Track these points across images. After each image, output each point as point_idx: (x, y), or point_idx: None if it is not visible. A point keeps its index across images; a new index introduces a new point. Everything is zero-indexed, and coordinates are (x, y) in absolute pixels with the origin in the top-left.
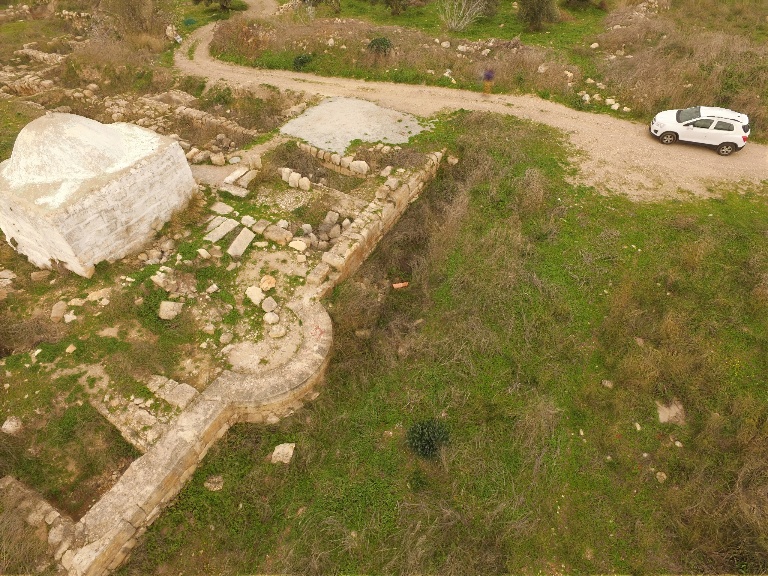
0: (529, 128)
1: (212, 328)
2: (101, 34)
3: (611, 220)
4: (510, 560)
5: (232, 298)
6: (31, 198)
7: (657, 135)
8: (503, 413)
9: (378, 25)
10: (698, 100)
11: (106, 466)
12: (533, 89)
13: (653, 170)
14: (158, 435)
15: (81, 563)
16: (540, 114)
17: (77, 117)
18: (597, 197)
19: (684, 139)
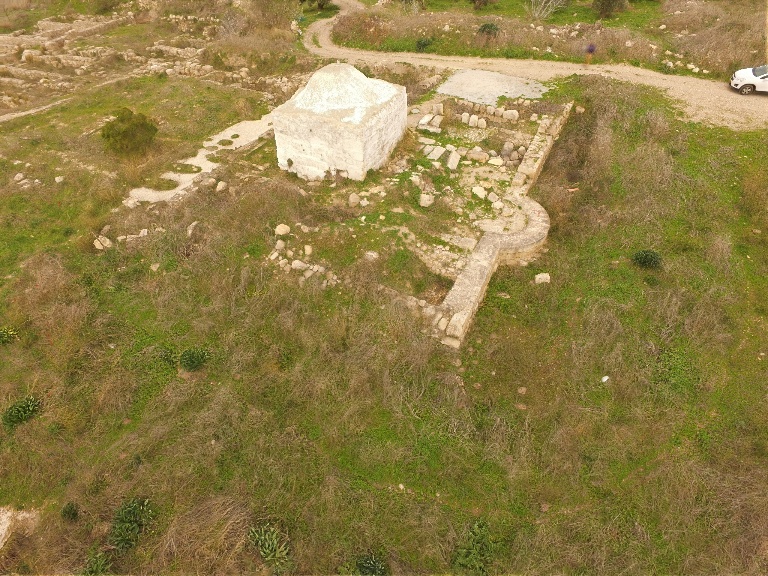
0: (634, 85)
1: (462, 210)
2: None
3: (723, 141)
4: (729, 314)
5: (464, 194)
6: (338, 118)
7: (737, 88)
8: (693, 247)
9: None
10: (764, 62)
11: (426, 288)
12: (625, 59)
13: (741, 111)
14: (465, 263)
15: (460, 320)
16: (636, 77)
17: None
18: (706, 128)
19: (760, 90)
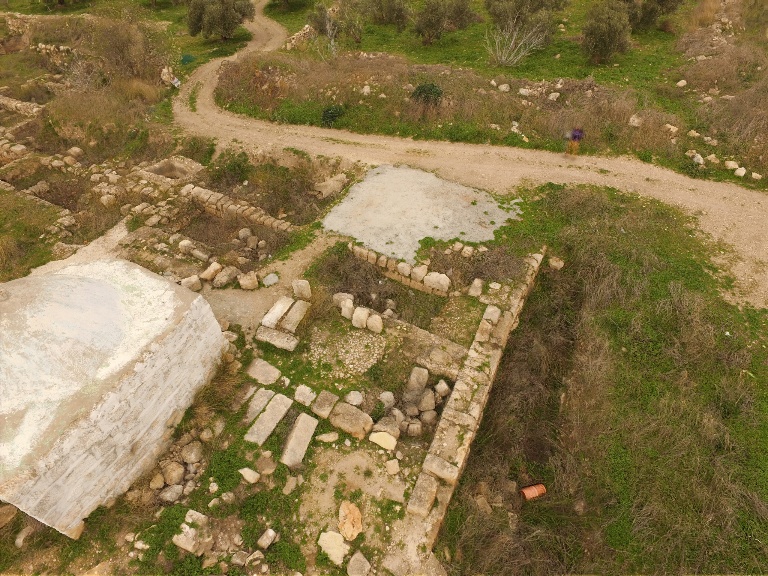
0: (646, 211)
1: None
2: (83, 78)
3: None
4: None
5: (299, 555)
6: None
7: None
8: None
9: (411, 59)
10: None
11: None
12: (629, 149)
13: None
14: None
15: None
16: (647, 185)
17: (48, 288)
18: None
19: None
